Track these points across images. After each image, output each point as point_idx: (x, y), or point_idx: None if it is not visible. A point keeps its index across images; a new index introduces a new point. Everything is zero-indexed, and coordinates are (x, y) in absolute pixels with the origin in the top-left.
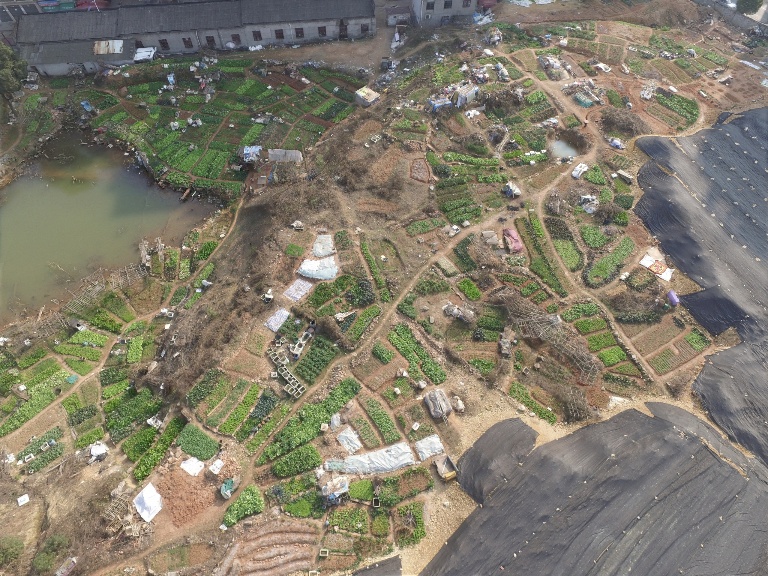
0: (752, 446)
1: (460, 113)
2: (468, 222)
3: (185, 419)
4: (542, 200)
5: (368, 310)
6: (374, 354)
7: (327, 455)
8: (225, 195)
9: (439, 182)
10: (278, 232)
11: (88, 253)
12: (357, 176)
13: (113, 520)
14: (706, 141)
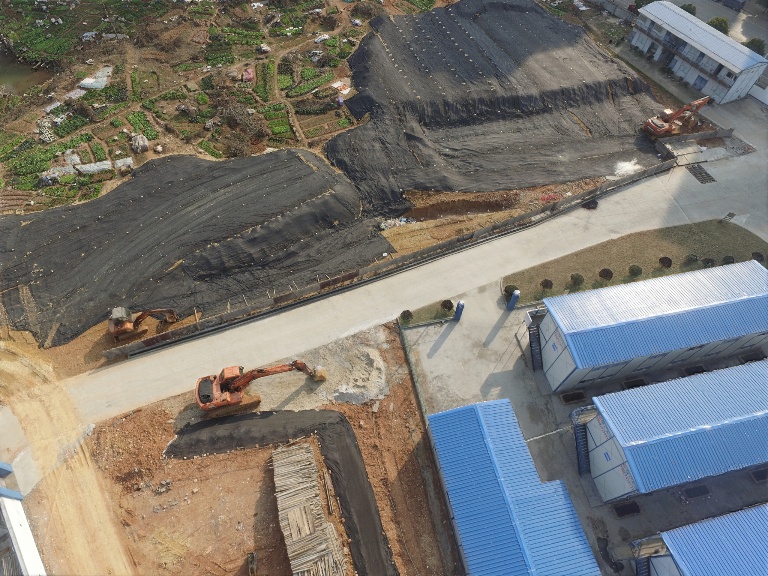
0: (343, 167)
1: (246, 4)
2: (220, 65)
3: None
4: (283, 54)
5: (119, 104)
6: (111, 123)
7: (55, 166)
8: (64, 63)
9: None
10: (74, 65)
11: None
12: (150, 39)
13: None
14: (414, 16)
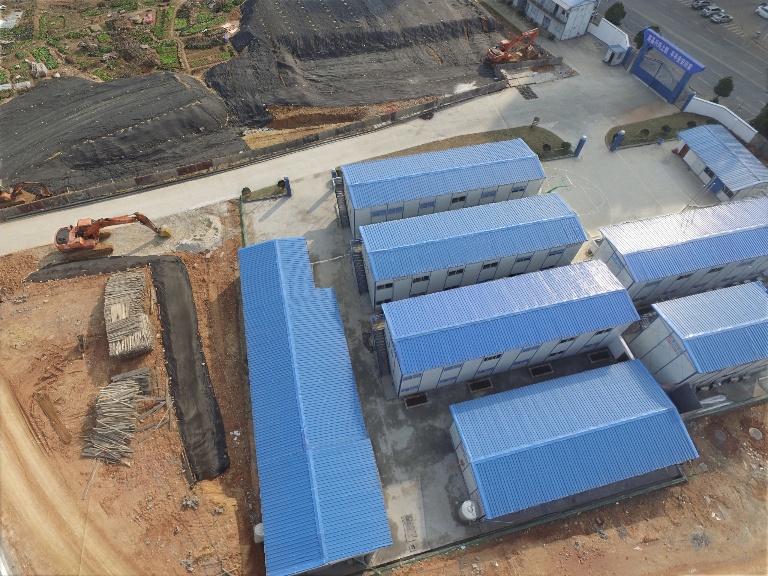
0: (217, 88)
1: None
2: None
3: None
4: None
5: (25, 41)
6: (15, 55)
7: None
8: None
9: None
10: None
11: None
12: None
13: None
14: None
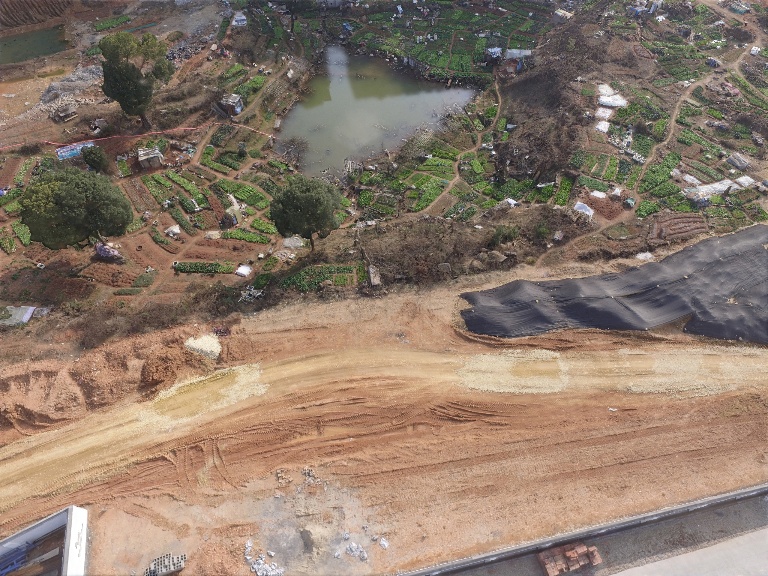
0: None
1: (653, 18)
2: (693, 79)
3: (572, 178)
4: (737, 67)
5: (659, 122)
6: (680, 141)
7: (682, 187)
8: (485, 80)
9: (659, 58)
10: (570, 83)
11: (397, 119)
12: None
13: (571, 215)
14: None
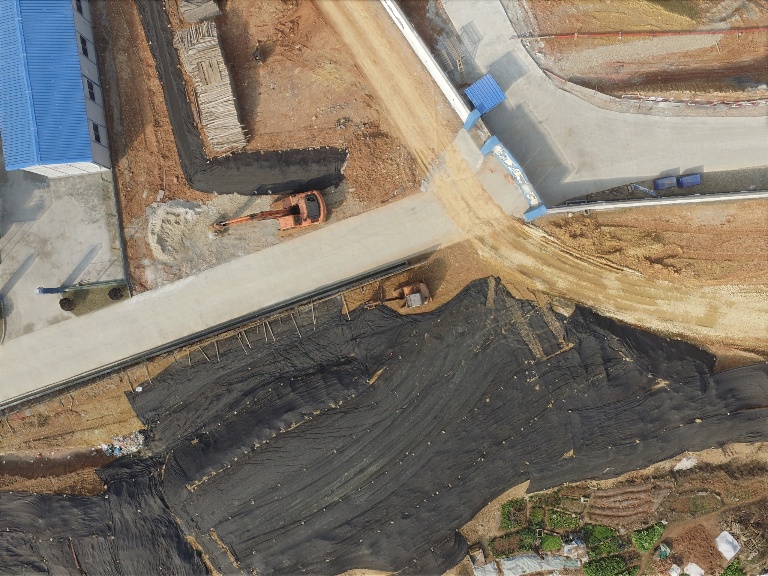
0: (184, 547)
1: None
2: None
3: None
4: None
5: None
6: None
7: (578, 572)
8: None
9: None
10: None
11: None
12: None
13: None
14: None
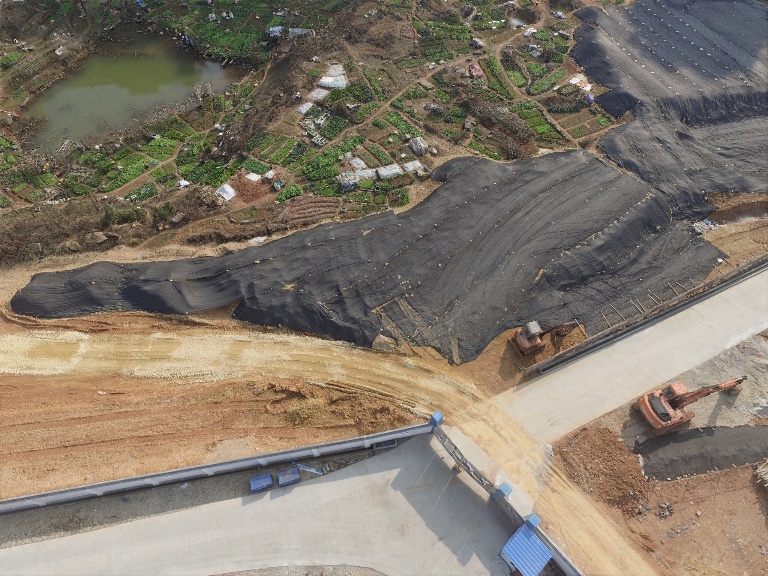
0: (632, 168)
1: None
2: (443, 61)
3: (245, 159)
4: (500, 49)
5: (369, 104)
6: (374, 124)
7: (343, 170)
8: (256, 60)
9: (422, 39)
10: (302, 63)
11: (153, 99)
12: (359, 34)
13: None
14: (626, 8)
